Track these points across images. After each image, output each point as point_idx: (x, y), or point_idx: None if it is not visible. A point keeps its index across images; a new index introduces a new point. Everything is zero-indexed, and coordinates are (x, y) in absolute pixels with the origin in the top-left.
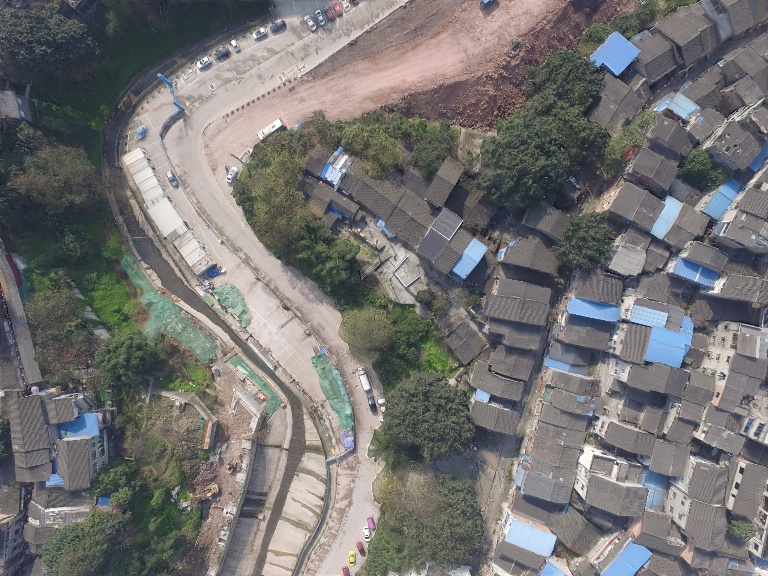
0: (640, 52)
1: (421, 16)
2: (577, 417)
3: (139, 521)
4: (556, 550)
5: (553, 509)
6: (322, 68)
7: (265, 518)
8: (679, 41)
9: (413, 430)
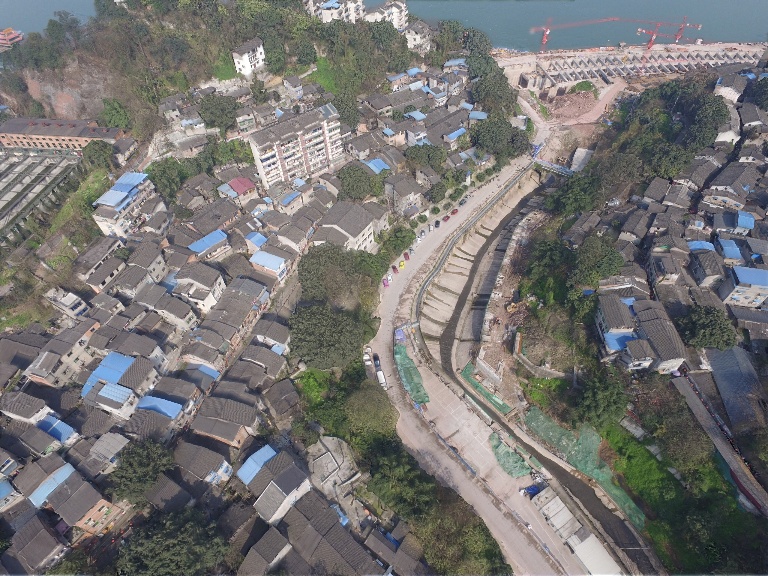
0: None
1: None
2: (207, 328)
3: (561, 284)
4: None
5: None
6: None
7: (472, 295)
8: None
9: None
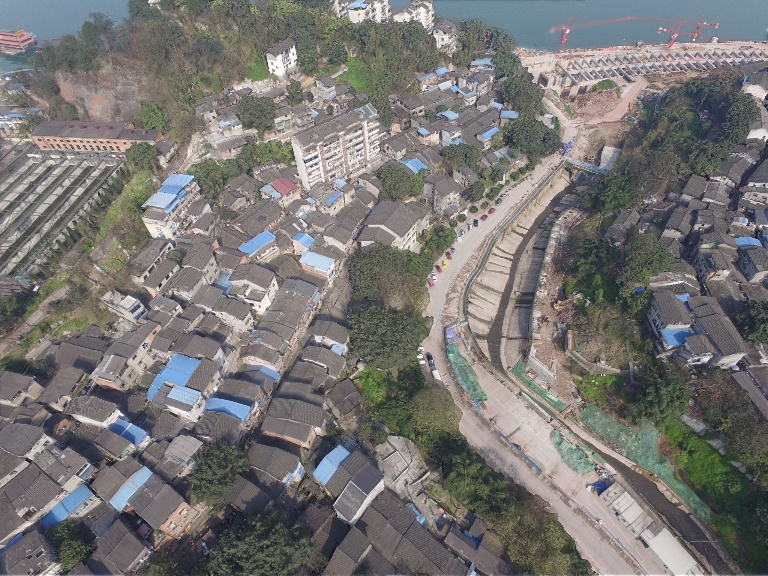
0: None
1: None
2: None
3: (609, 281)
4: None
5: None
6: None
7: (514, 293)
8: None
9: None
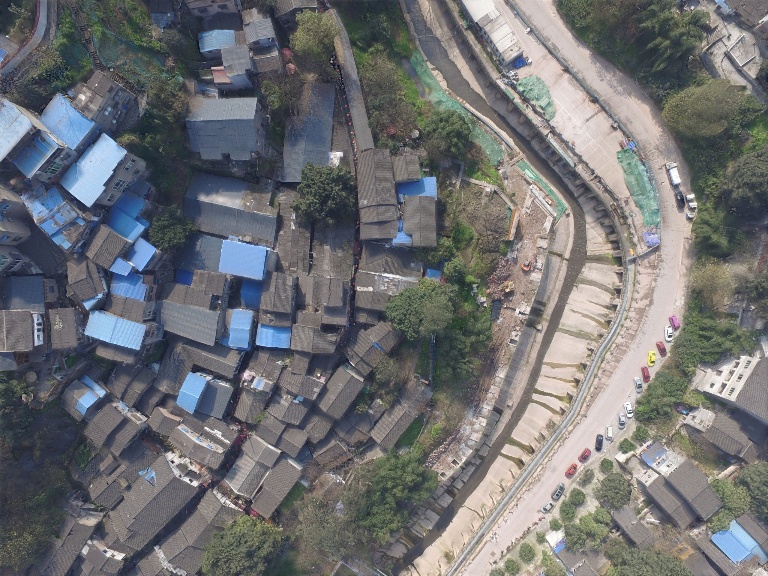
0: None
1: None
2: None
3: None
4: None
5: None
6: None
7: (542, 329)
8: None
9: None
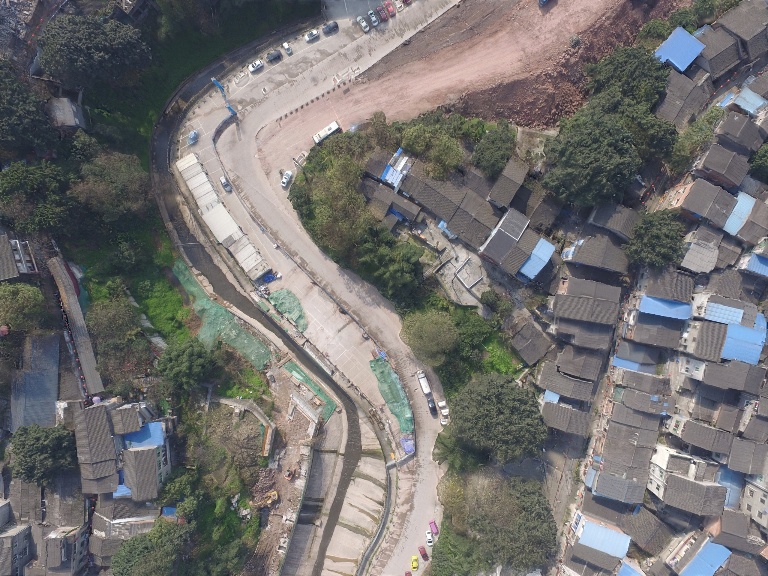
0: (704, 47)
1: (477, 15)
2: (650, 416)
3: (202, 530)
4: (627, 551)
5: (624, 509)
6: (376, 69)
7: (322, 524)
8: (744, 35)
9: (485, 433)
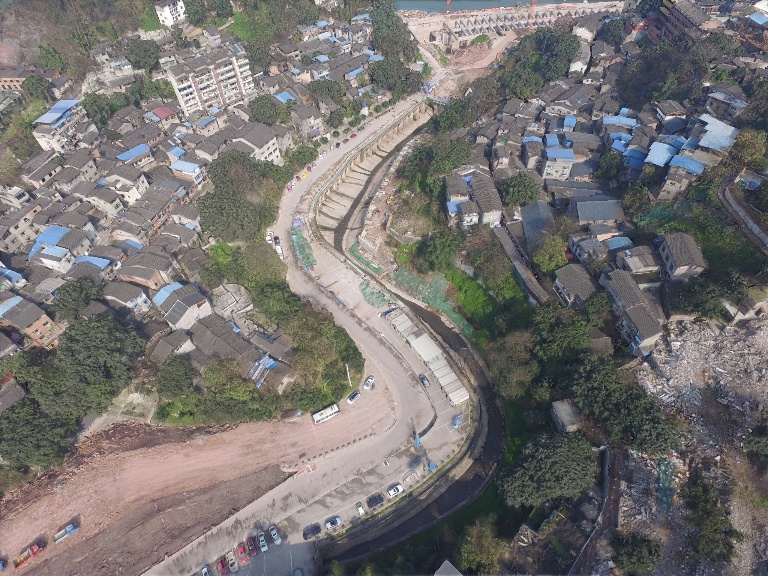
0: None
1: (149, 531)
2: None
3: None
4: None
5: None
6: (269, 480)
7: None
8: None
9: None
